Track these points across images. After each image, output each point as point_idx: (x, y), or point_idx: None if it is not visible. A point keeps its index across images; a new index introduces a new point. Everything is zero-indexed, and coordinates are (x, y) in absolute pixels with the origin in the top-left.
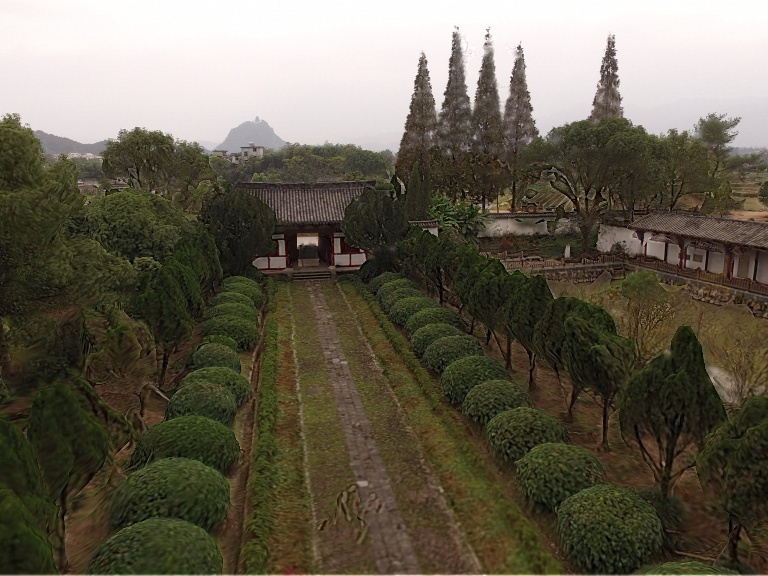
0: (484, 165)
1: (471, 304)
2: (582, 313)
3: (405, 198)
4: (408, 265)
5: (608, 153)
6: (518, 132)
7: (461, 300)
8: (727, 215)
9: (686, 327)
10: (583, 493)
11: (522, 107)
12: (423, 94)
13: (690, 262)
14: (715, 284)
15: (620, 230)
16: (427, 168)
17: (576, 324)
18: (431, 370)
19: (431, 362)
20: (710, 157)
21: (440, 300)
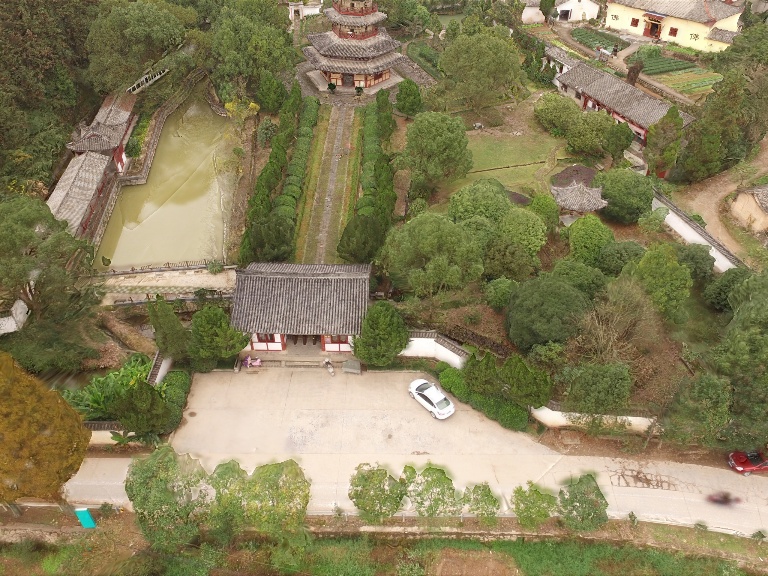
0: None
1: None
2: None
3: None
4: None
5: None
6: None
7: None
8: None
9: None
10: (305, 140)
11: None
12: None
13: None
14: None
15: None
16: None
17: None
18: None
19: None
20: None
21: None
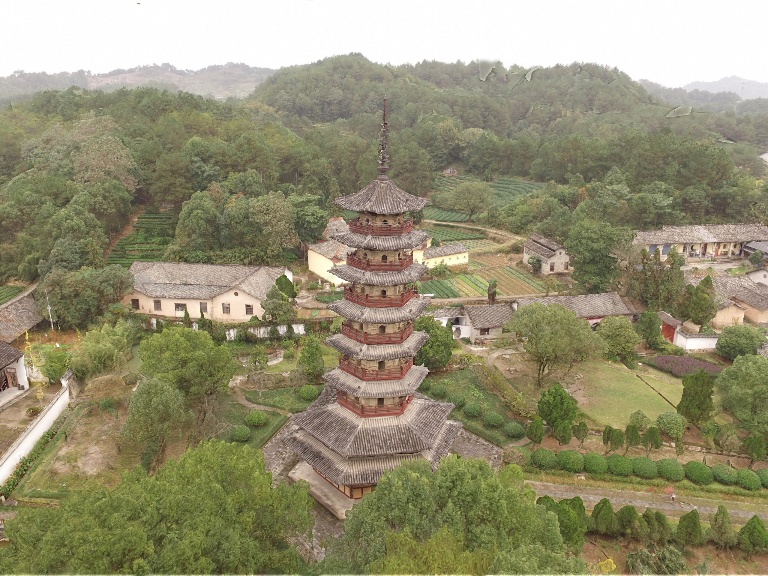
0: None
1: None
2: None
3: None
4: None
5: None
6: None
7: None
8: None
9: None
10: None
11: None
12: None
13: None
14: None
15: None
16: None
17: None
18: None
19: None
20: None
21: None
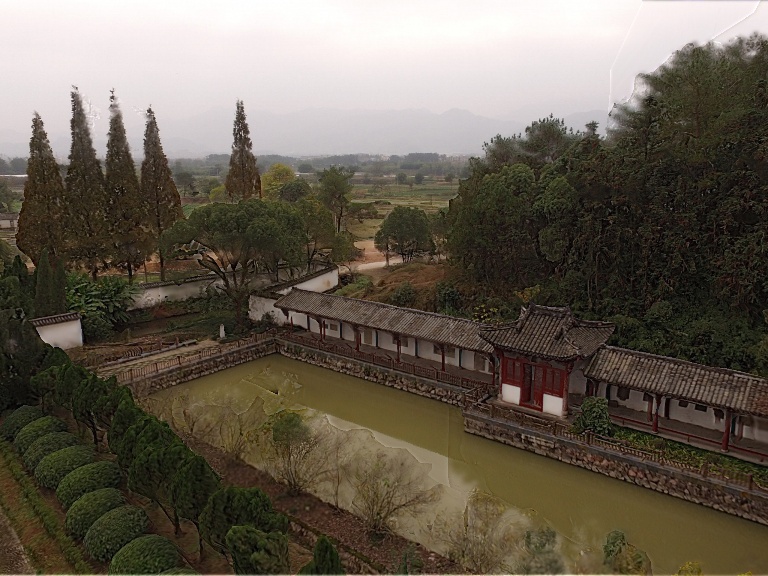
0: (125, 232)
1: (131, 482)
2: (240, 503)
3: (34, 281)
4: (50, 401)
5: (249, 239)
6: (158, 195)
7: (119, 465)
8: (353, 261)
9: (323, 538)
10: None
11: (159, 170)
12: (42, 159)
13: (328, 330)
14: (349, 358)
15: (268, 301)
16: (58, 241)
17: (236, 537)
18: (95, 561)
19: (94, 552)
20: (335, 203)
21: (94, 441)
